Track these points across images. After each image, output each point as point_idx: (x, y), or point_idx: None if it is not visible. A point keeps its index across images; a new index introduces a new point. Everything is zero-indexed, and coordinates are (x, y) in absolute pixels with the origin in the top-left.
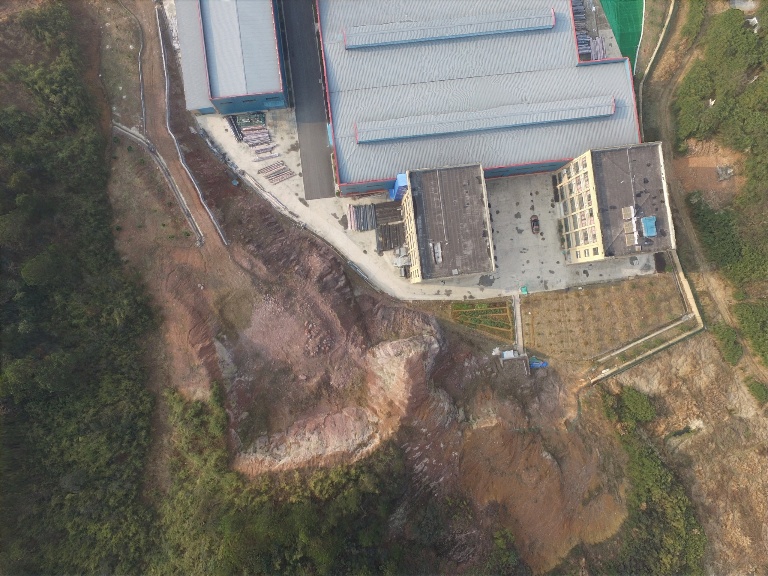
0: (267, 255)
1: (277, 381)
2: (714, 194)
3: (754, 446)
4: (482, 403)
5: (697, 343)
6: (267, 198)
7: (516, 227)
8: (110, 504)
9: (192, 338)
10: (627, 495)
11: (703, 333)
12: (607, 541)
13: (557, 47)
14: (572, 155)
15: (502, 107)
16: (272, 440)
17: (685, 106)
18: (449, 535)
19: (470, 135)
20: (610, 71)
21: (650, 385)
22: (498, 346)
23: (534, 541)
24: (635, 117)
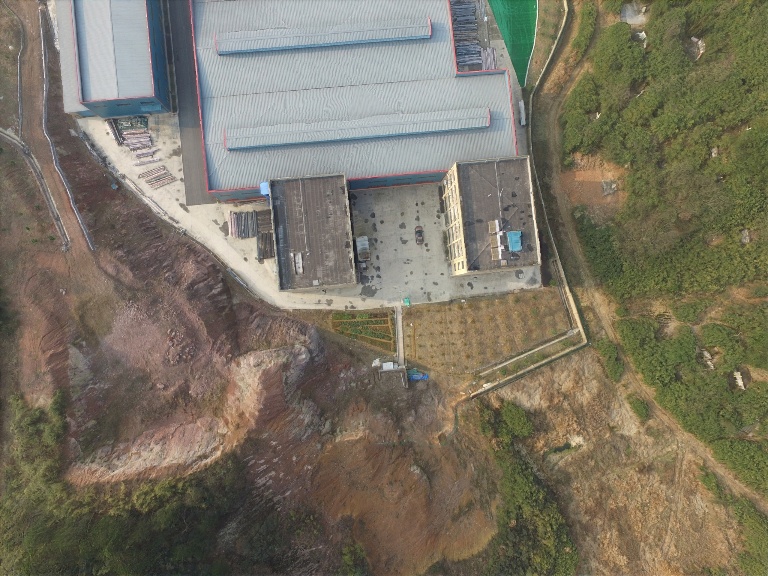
0: (137, 261)
1: (134, 389)
2: (599, 209)
3: (634, 464)
4: (353, 415)
5: (580, 359)
6: (147, 203)
7: (400, 237)
8: None
9: (44, 344)
10: (498, 511)
11: (587, 349)
12: (472, 558)
13: (436, 57)
14: (448, 166)
15: (375, 117)
16: (116, 450)
17: (570, 119)
18: (290, 550)
19: (344, 144)
20: (490, 82)
21: (531, 400)
22: (379, 357)
23: (392, 557)
24: (513, 130)
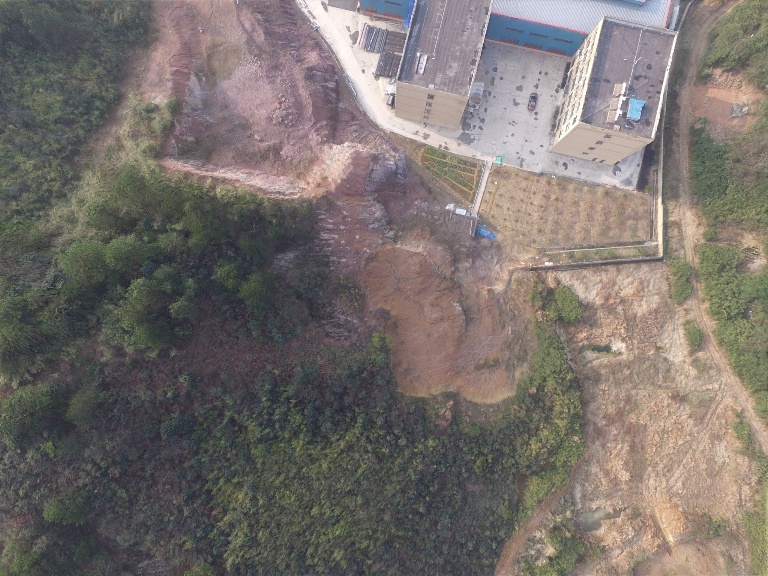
0: (271, 30)
1: (234, 132)
2: (721, 128)
3: (669, 389)
4: (416, 238)
5: (650, 270)
6: None
7: (514, 98)
8: (42, 148)
9: (173, 61)
10: (521, 376)
11: (660, 263)
12: (484, 405)
13: None
14: (589, 32)
15: None
16: (205, 167)
17: (723, 32)
18: (329, 307)
19: None
20: None
21: (587, 293)
22: (454, 203)
23: (412, 369)
24: (665, 15)
